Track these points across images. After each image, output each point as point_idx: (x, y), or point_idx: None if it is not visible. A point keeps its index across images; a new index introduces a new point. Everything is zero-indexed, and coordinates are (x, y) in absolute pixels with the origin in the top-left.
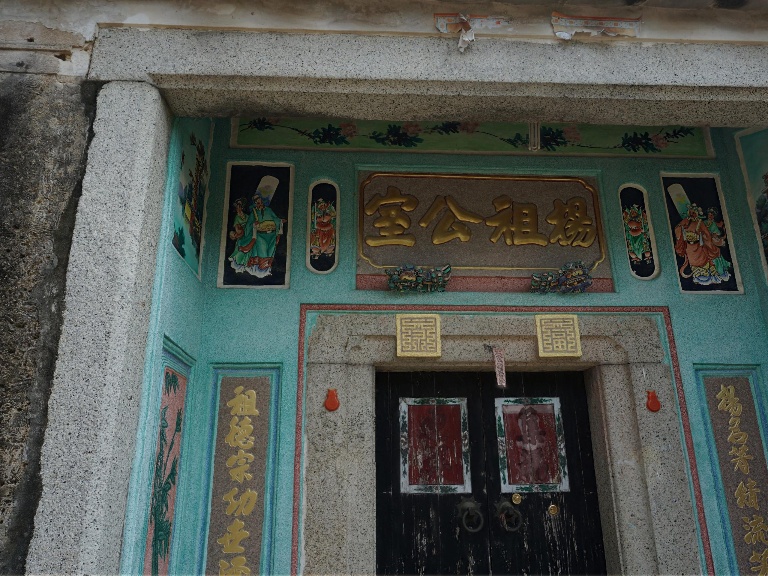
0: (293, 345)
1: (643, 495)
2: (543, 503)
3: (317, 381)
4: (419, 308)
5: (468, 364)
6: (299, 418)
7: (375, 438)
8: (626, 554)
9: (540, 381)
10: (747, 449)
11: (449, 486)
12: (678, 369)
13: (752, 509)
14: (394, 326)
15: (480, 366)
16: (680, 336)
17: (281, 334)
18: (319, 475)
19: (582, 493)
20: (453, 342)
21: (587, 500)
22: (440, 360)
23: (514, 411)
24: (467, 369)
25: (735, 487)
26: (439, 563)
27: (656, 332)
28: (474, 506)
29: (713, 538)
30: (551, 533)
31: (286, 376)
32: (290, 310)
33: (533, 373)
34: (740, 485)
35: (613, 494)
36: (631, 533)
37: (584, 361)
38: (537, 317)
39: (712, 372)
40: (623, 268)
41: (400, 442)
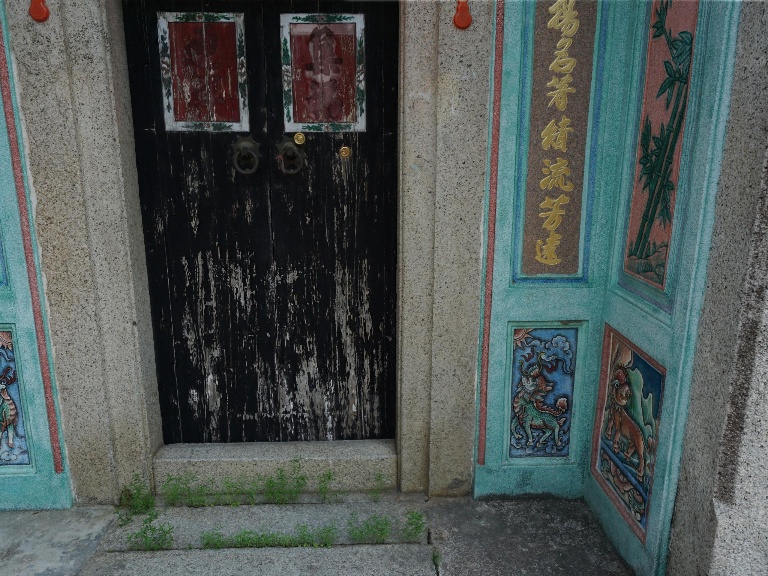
0: None
1: (434, 134)
2: (333, 144)
3: None
4: None
5: None
6: None
7: (126, 63)
8: (405, 198)
9: None
10: (571, 80)
11: (223, 123)
12: None
13: (558, 151)
14: None
15: None
16: None
17: None
18: (37, 103)
19: (380, 134)
20: None
21: (385, 142)
22: None
23: (304, 32)
24: None
25: (544, 126)
26: (213, 206)
27: None
28: (251, 146)
29: (502, 182)
30: (340, 177)
31: None
32: None
33: None
34: (551, 123)
35: (401, 133)
36: (414, 176)
37: None
38: None
39: None
40: None
41: (161, 70)
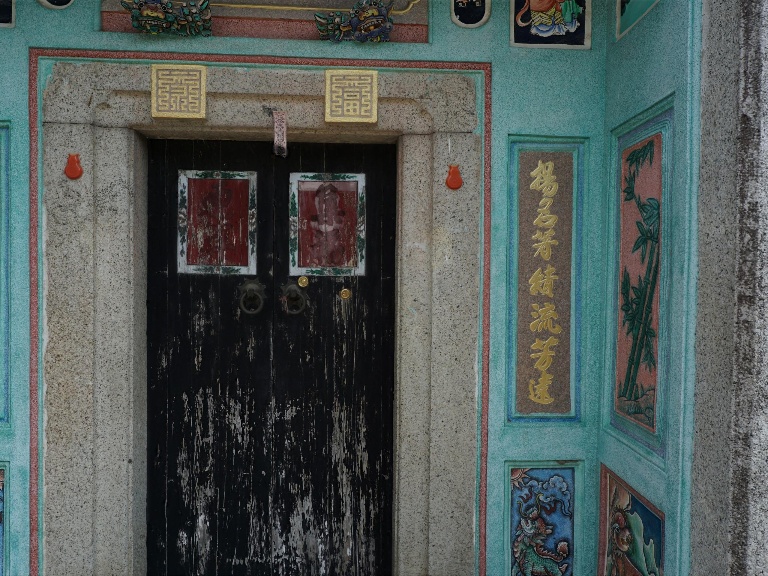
0: (21, 99)
1: (429, 280)
2: (334, 287)
3: (56, 144)
4: (178, 57)
5: (245, 130)
6: (33, 186)
7: (146, 214)
8: (402, 338)
9: (344, 154)
10: (553, 233)
11: (232, 267)
12: (489, 140)
13: (545, 296)
14: (149, 79)
15: (261, 133)
16: (498, 100)
17: (6, 85)
18: (61, 250)
19: (379, 278)
20: (225, 102)
21: (383, 285)
22: (209, 124)
23: (311, 188)
24: (253, 137)
25: (531, 273)
26: (217, 343)
27: (473, 95)
28: (257, 288)
29: (494, 324)
30: (340, 317)
31: (15, 137)
32: (16, 55)
33: (337, 145)
34: (537, 271)
35: (399, 278)
36: (411, 318)
37: (383, 129)
38: (327, 72)
39: (531, 145)
40: (442, 11)
41: (178, 219)
